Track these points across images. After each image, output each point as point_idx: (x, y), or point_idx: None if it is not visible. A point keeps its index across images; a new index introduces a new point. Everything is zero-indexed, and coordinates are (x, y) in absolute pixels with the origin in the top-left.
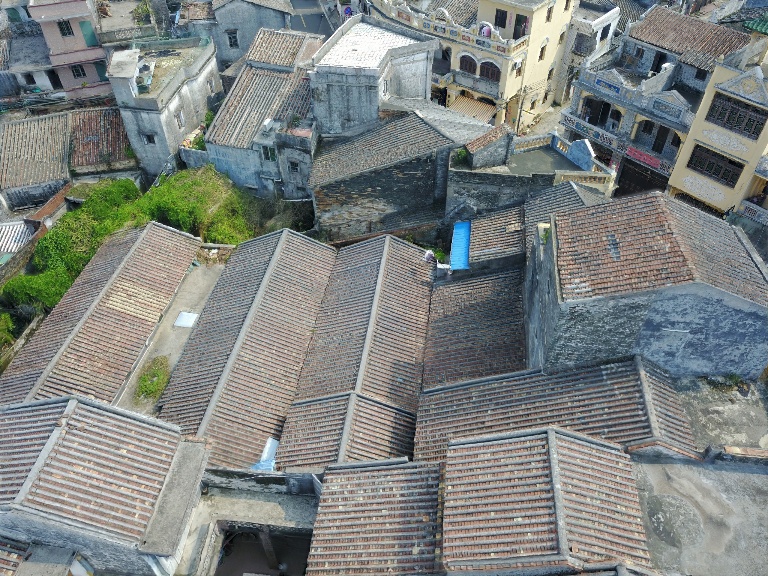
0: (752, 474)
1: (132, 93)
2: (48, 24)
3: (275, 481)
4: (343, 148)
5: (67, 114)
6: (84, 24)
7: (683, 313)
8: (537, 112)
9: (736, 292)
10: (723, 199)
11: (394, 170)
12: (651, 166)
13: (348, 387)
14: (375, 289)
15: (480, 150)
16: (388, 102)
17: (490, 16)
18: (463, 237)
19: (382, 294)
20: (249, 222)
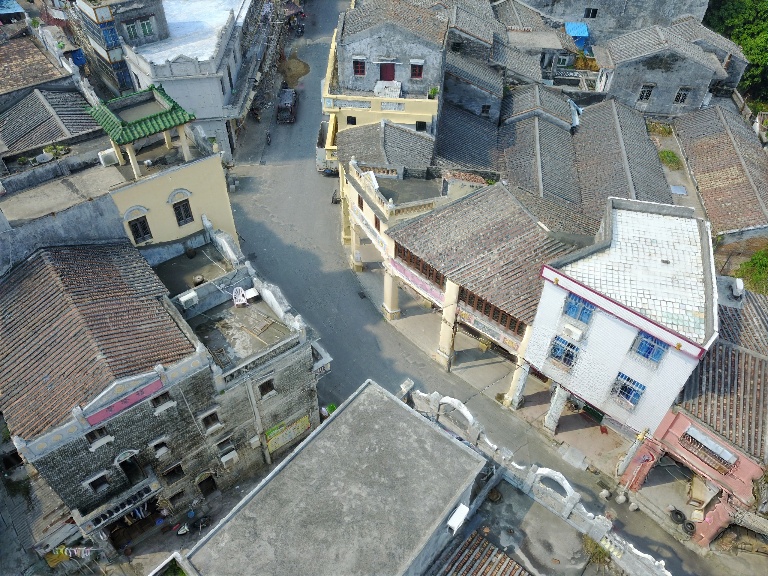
0: None
1: None
2: None
3: None
4: None
5: None
6: None
7: None
8: None
9: (373, 2)
10: None
11: None
12: None
13: None
14: None
15: None
16: None
17: None
18: None
19: None
20: None
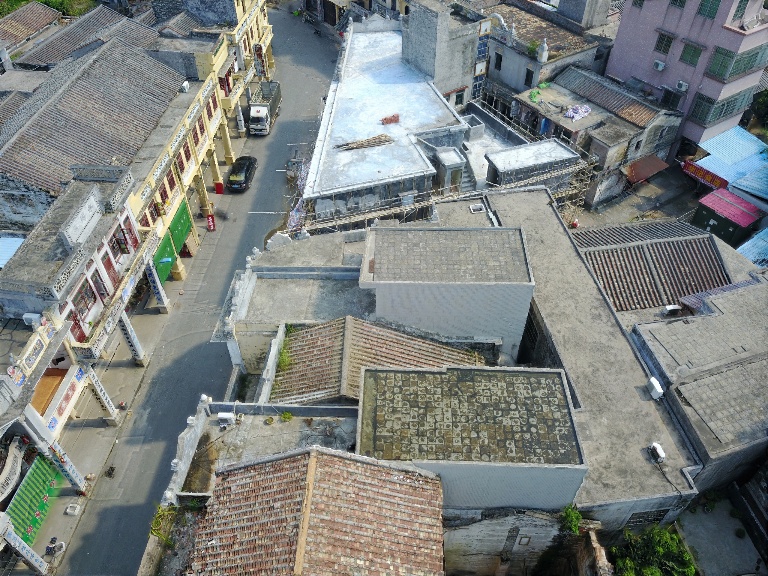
0: None
1: None
2: None
3: (45, 70)
4: None
5: None
6: None
7: None
8: None
9: None
10: (343, 2)
11: None
12: None
13: None
14: None
15: None
16: None
17: None
18: None
19: None
20: None
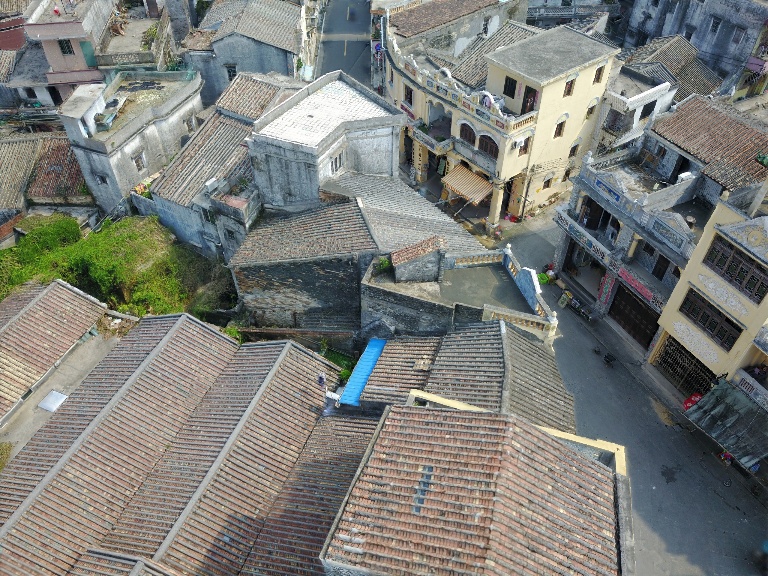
0: None
1: (82, 133)
2: (48, 42)
3: None
4: (280, 224)
5: (38, 140)
6: (85, 44)
7: None
8: (554, 191)
9: None
10: (715, 361)
11: (314, 266)
12: (643, 296)
13: (157, 540)
14: (244, 411)
15: (404, 263)
16: (336, 180)
17: (499, 83)
18: (371, 360)
19: (251, 419)
20: (183, 284)
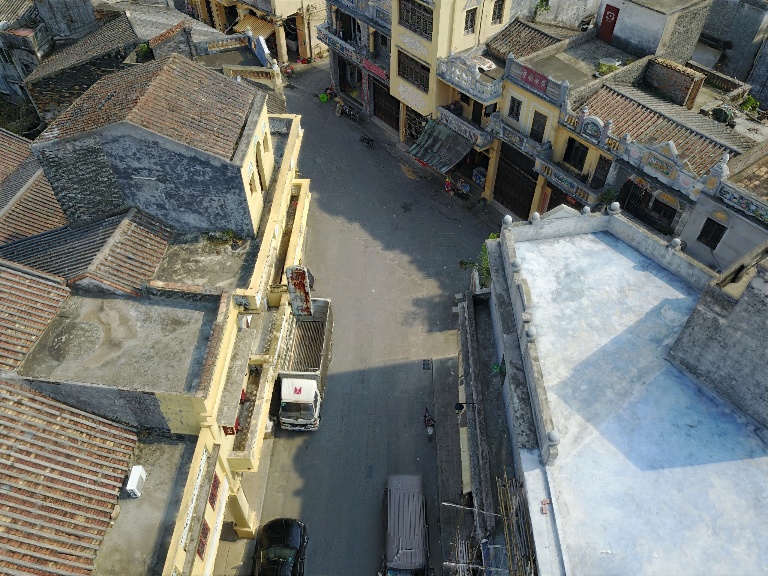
0: (181, 309)
1: None
2: None
3: None
4: (67, 49)
5: None
6: None
7: (136, 158)
8: None
9: (170, 135)
10: (424, 106)
11: (91, 66)
12: (380, 77)
13: None
14: (34, 174)
15: (158, 44)
16: (111, 4)
17: None
18: None
19: (40, 179)
20: None
